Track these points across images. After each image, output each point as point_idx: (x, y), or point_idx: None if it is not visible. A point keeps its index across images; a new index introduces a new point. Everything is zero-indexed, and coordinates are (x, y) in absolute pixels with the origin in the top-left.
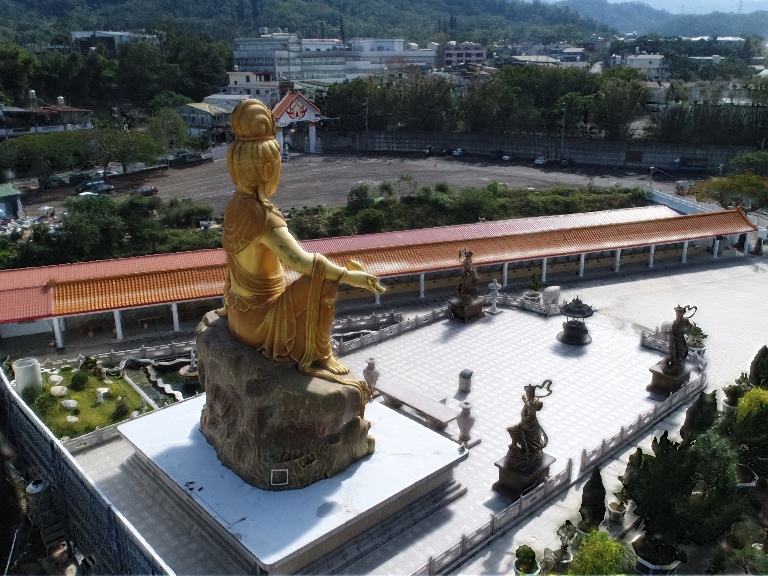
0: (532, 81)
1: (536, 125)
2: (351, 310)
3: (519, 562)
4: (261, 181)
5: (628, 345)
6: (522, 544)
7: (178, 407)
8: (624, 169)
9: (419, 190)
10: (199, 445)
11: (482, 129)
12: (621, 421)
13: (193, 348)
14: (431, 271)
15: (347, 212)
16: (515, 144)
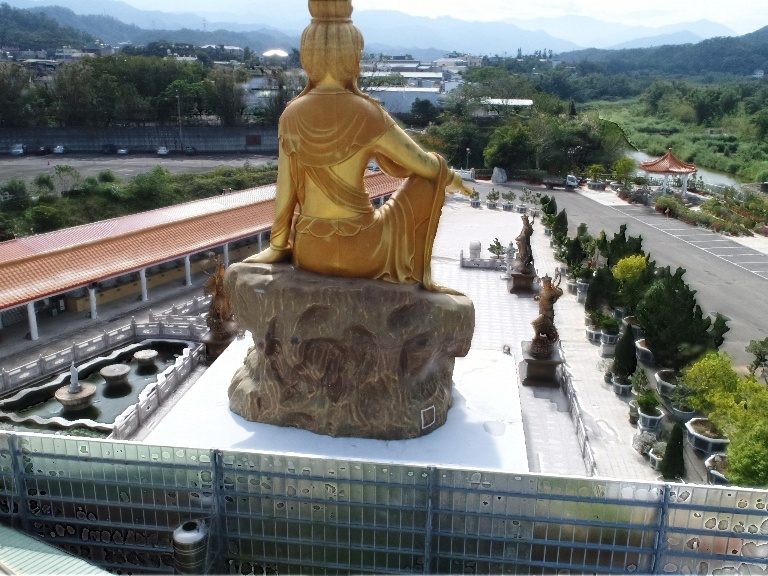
0: (120, 71)
1: (146, 115)
2: (170, 296)
3: (646, 411)
4: (356, 73)
5: (453, 269)
6: (595, 412)
7: (178, 412)
8: (247, 153)
9: (83, 181)
10: (275, 432)
11: (84, 122)
12: (528, 316)
13: (30, 373)
14: (235, 240)
15: (6, 214)
16: (126, 136)
